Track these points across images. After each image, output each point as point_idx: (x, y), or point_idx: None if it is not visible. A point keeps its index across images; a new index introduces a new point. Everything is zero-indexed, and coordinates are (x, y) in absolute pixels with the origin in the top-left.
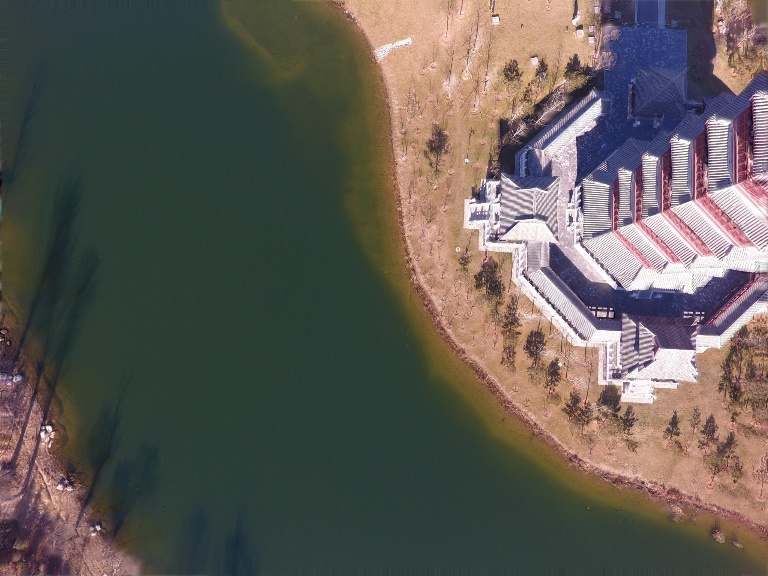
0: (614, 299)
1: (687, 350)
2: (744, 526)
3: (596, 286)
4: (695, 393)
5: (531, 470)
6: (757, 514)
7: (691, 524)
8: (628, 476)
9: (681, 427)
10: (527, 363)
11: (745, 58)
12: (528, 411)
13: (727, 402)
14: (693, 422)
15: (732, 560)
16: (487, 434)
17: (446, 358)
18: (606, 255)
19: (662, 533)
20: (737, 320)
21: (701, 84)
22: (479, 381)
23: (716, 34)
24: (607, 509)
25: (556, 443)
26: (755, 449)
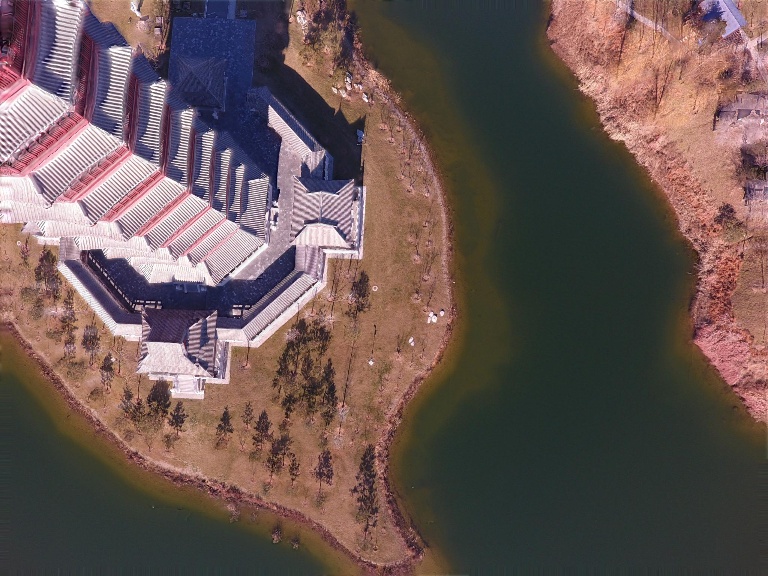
0: (162, 292)
1: (171, 343)
2: (306, 526)
3: (145, 279)
4: (248, 388)
5: (95, 468)
6: (317, 513)
7: (254, 524)
8: (189, 474)
9: (233, 423)
10: (86, 358)
11: (305, 47)
12: (90, 407)
13: (281, 398)
14: (246, 418)
15: (296, 561)
16: (54, 431)
17: (15, 354)
18: None
19: (225, 533)
20: (263, 313)
21: (270, 74)
22: (43, 377)
23: (292, 24)
24: (172, 508)
25: (118, 440)
26: (312, 446)
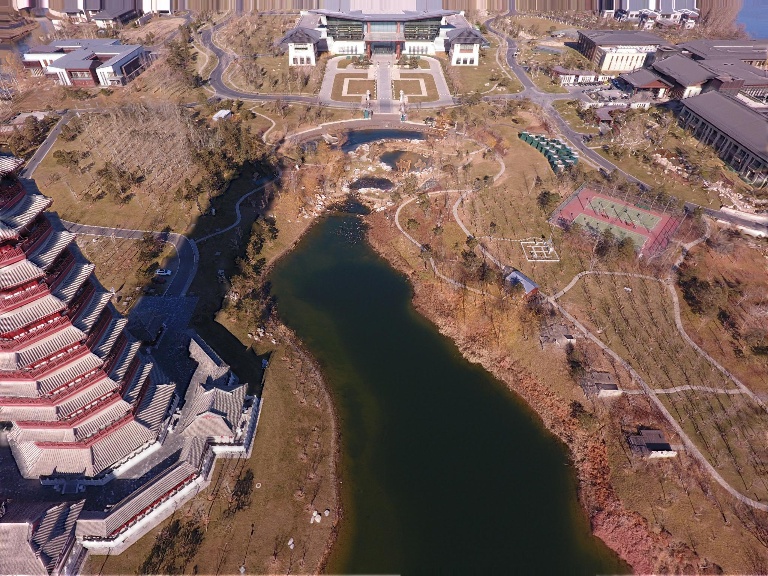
0: (38, 495)
1: (20, 523)
2: None
3: (26, 482)
4: None
5: None
6: None
7: None
8: None
9: None
10: None
11: None
12: None
13: None
14: None
15: None
16: None
17: None
18: (25, 443)
19: None
20: (133, 502)
21: (201, 326)
22: None
23: (226, 299)
24: None
25: None
26: None
